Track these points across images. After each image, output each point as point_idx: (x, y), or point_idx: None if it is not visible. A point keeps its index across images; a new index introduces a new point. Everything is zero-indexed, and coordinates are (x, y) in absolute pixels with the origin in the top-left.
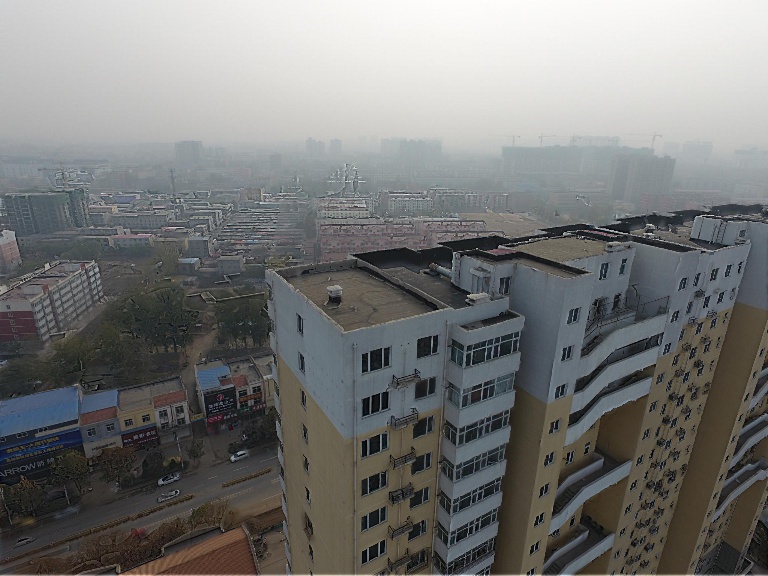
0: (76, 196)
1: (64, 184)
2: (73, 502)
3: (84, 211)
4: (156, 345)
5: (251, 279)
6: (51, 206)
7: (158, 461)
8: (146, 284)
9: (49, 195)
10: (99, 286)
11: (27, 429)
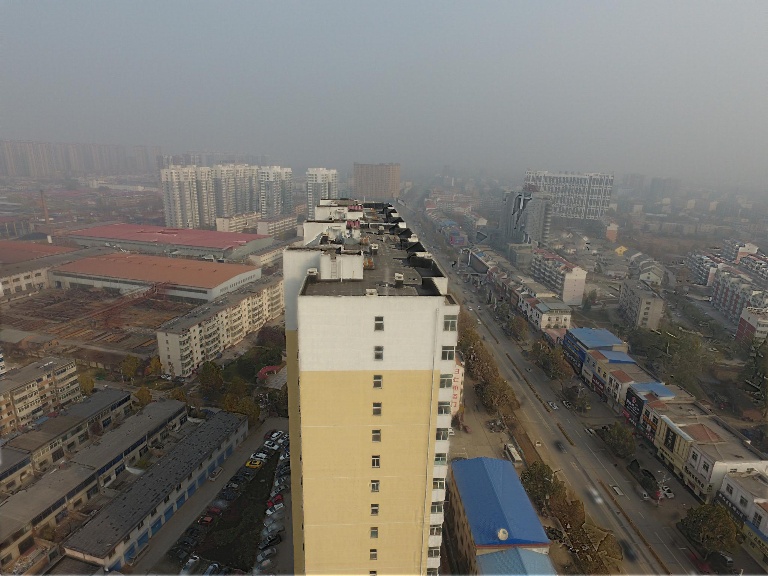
0: None
1: None
2: (552, 378)
3: None
4: (764, 396)
5: None
6: None
7: (572, 390)
8: None
9: None
10: None
11: (577, 336)
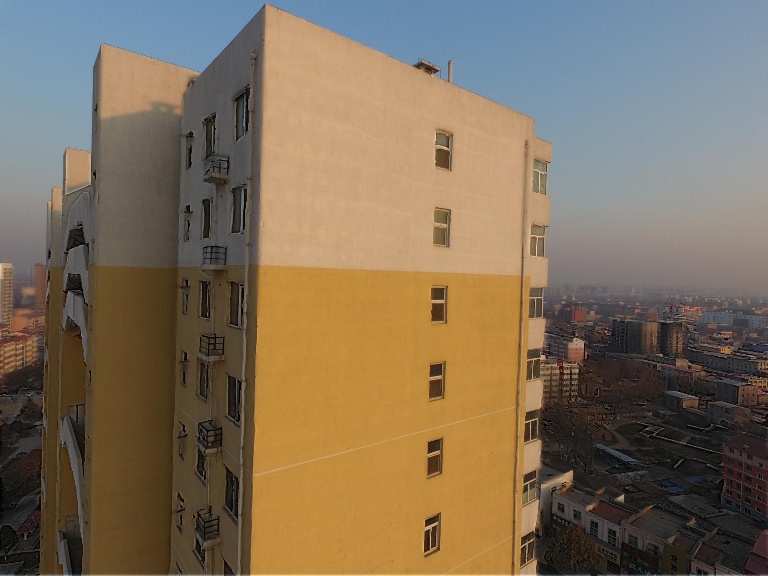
0: (670, 328)
1: (670, 317)
2: None
3: (677, 344)
4: None
5: (731, 436)
6: (640, 332)
7: None
8: (597, 393)
9: (641, 322)
10: (574, 386)
11: None
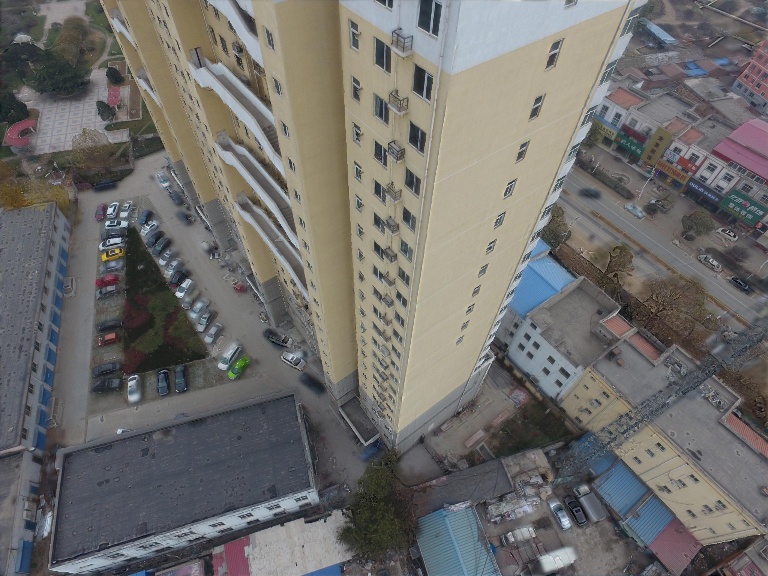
0: None
1: None
2: None
3: None
4: None
5: None
6: None
7: None
8: None
9: None
10: None
11: None
